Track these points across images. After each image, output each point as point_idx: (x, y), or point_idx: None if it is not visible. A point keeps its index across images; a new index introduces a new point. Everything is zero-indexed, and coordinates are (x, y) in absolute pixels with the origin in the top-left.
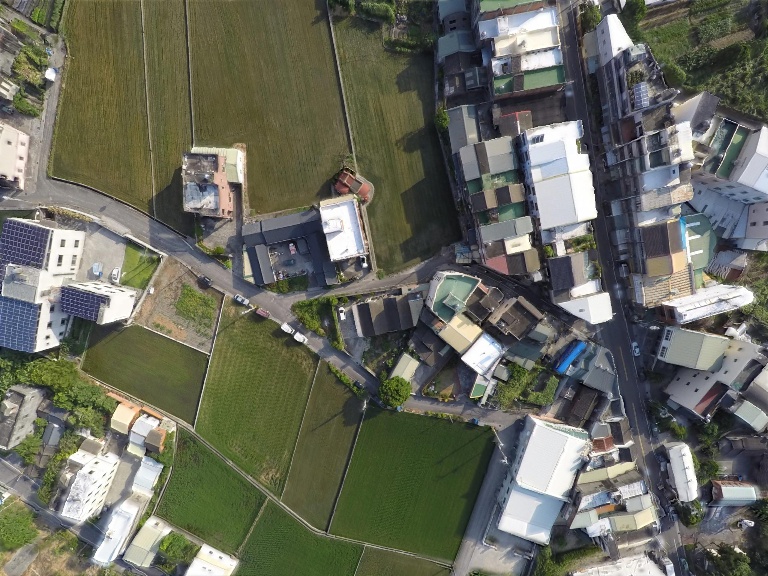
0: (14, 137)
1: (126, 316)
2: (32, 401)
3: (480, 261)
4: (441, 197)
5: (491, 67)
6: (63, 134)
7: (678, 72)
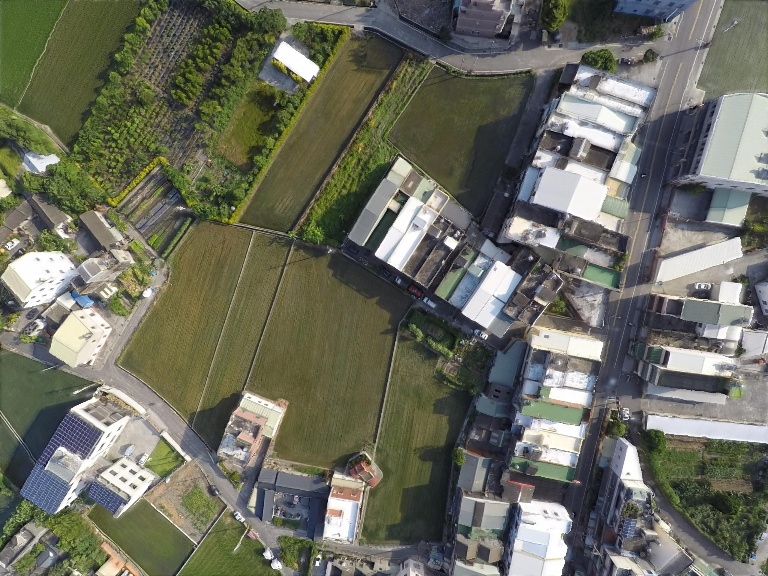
0: (99, 335)
1: (139, 496)
2: (39, 536)
3: (448, 573)
4: (436, 503)
5: (514, 447)
6: (140, 337)
7: (673, 499)
